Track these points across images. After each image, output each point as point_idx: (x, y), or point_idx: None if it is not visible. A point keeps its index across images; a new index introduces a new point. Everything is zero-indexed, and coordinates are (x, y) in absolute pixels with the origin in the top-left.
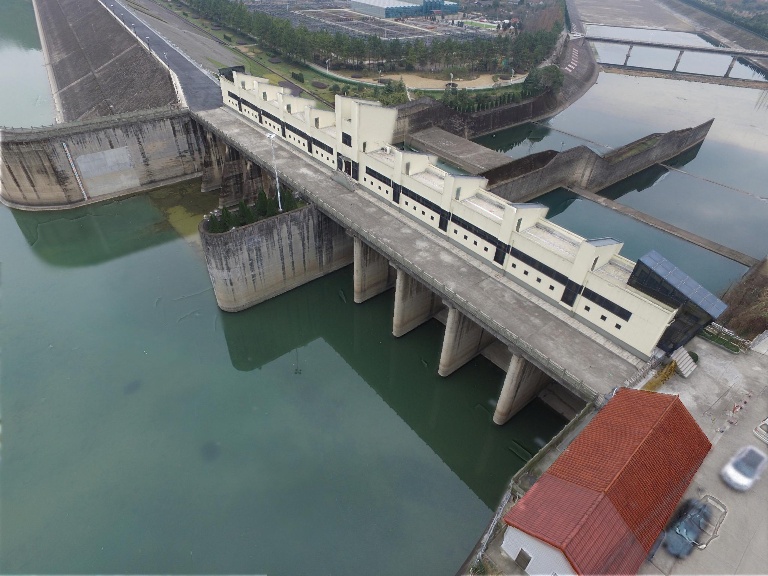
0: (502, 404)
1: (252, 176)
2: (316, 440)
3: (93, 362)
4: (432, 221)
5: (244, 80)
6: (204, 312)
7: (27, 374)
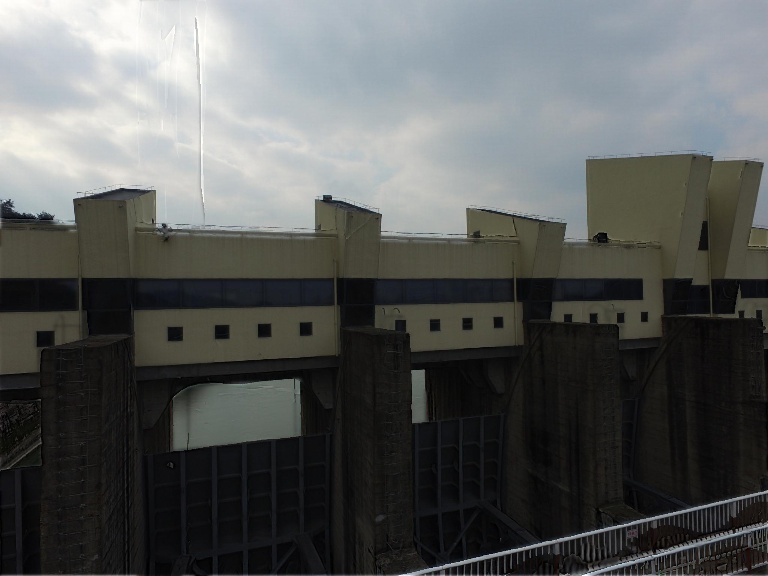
0: None
1: None
2: None
3: None
4: None
5: None
6: None
7: None
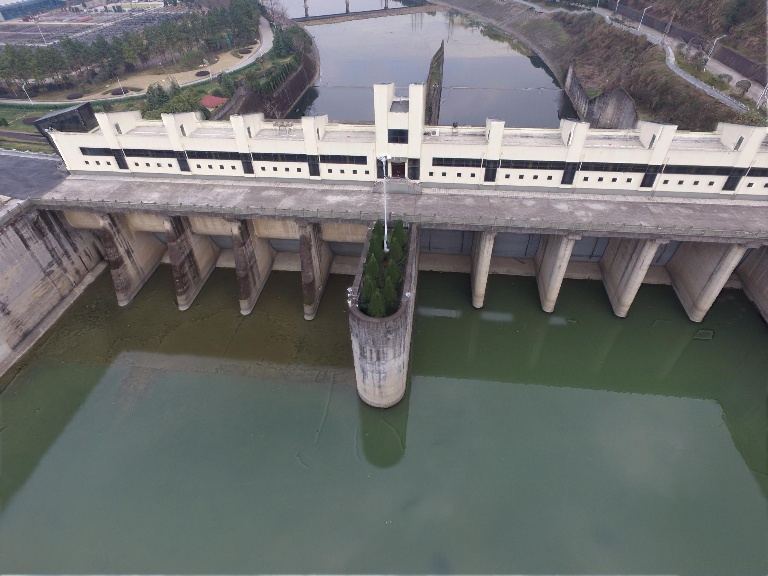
0: (712, 301)
1: (244, 240)
2: (643, 442)
3: None
4: (550, 181)
5: (116, 122)
6: (367, 427)
7: None
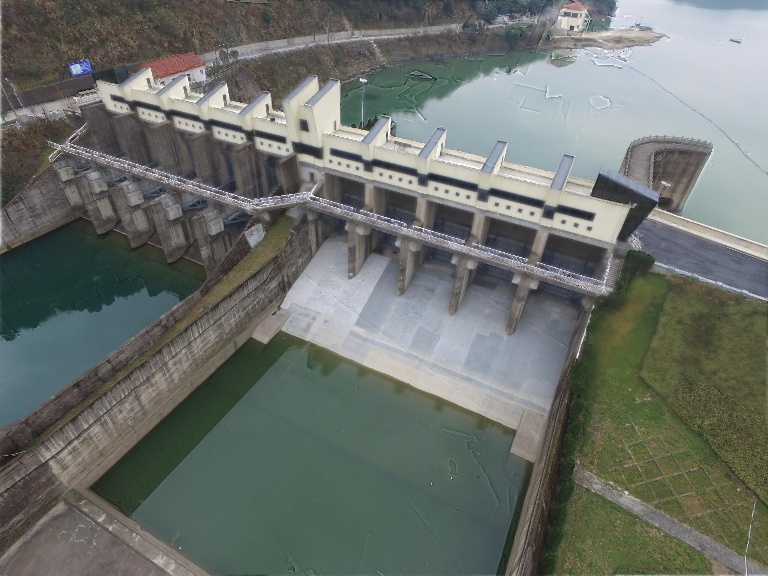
0: None
1: None
2: None
3: None
4: None
5: None
6: None
7: None
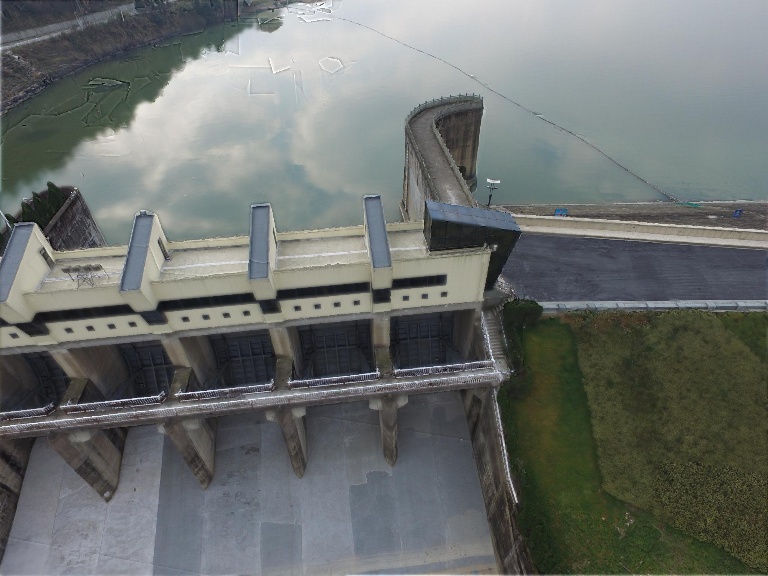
0: None
1: None
2: None
3: (143, 208)
4: None
5: None
6: None
7: (169, 188)
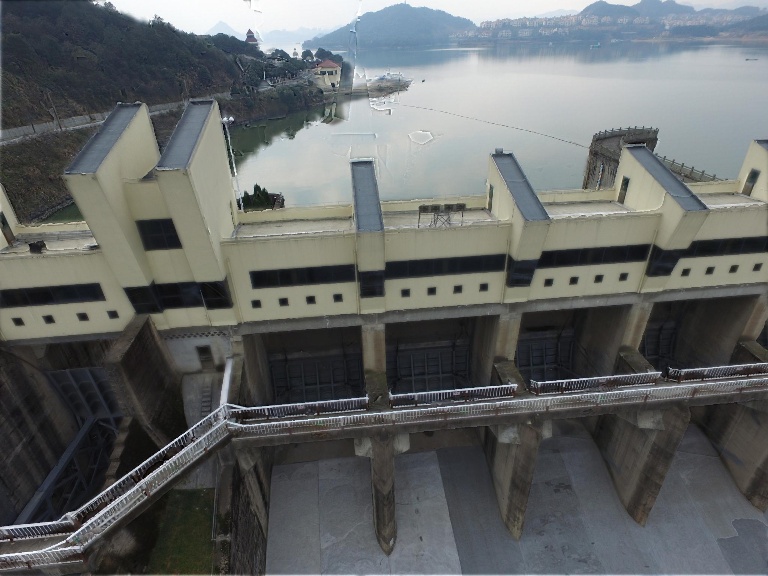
0: None
1: None
2: None
3: None
4: None
5: (763, 169)
6: None
7: None
